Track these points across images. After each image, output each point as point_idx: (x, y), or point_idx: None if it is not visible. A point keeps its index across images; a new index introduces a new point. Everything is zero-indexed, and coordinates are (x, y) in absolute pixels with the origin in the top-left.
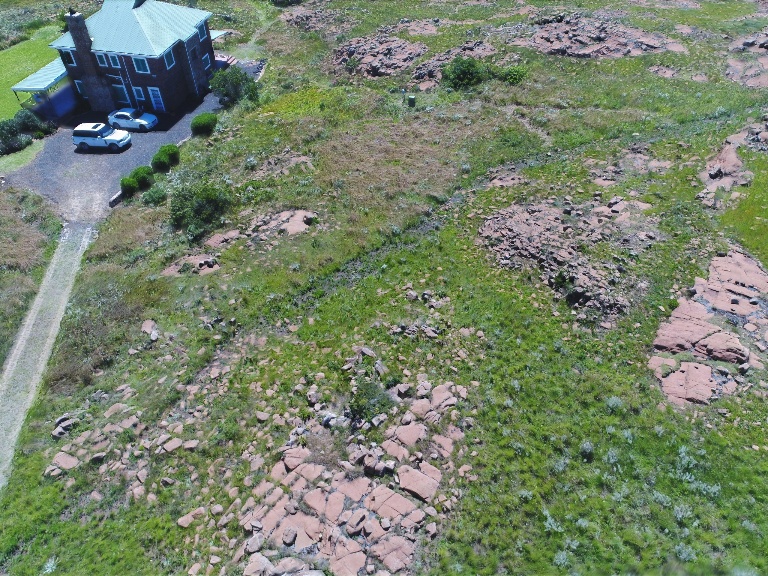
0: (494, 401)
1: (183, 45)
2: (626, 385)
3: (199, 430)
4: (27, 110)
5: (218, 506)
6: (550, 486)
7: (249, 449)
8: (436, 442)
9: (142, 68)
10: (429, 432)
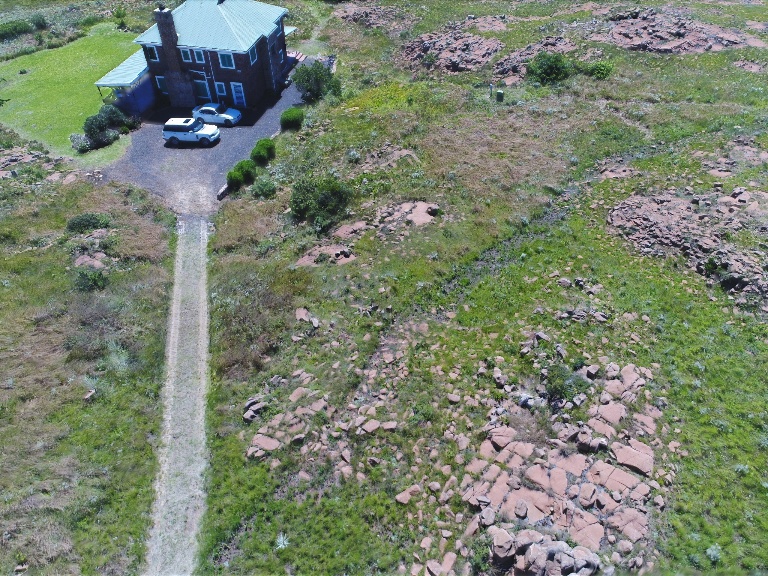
0: (682, 381)
1: (265, 41)
2: None
3: (391, 412)
4: (111, 105)
5: (435, 483)
6: (763, 460)
7: (451, 429)
8: (638, 420)
9: (227, 63)
10: (628, 411)
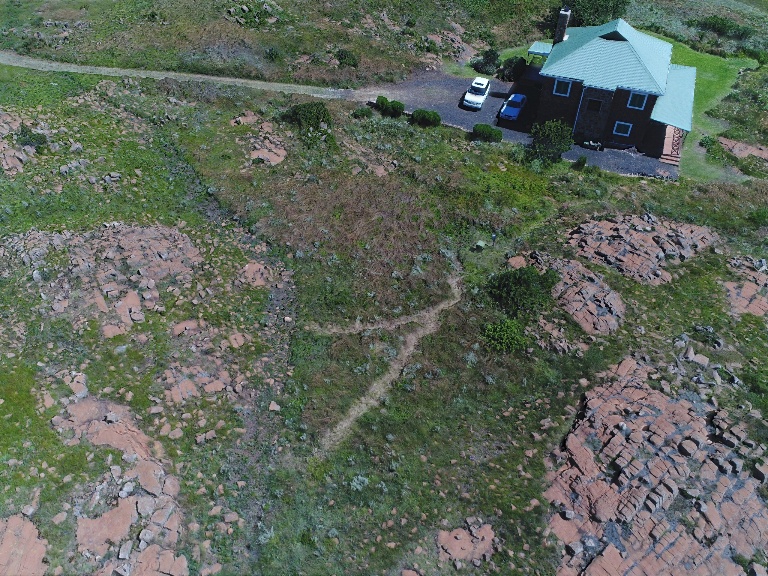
0: None
1: (583, 88)
2: None
3: None
4: (519, 59)
5: (33, 110)
6: None
7: None
8: None
9: None
10: None
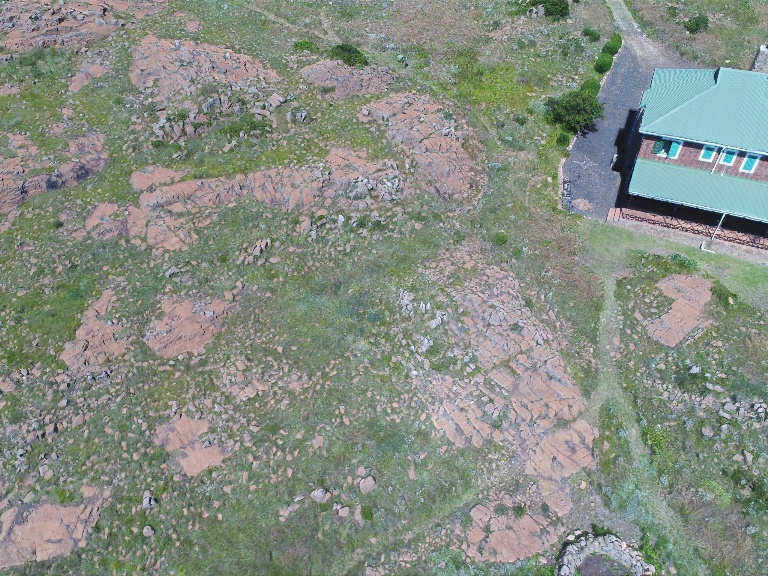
0: None
1: None
2: None
3: None
4: None
5: None
6: None
7: None
8: None
9: None
10: None
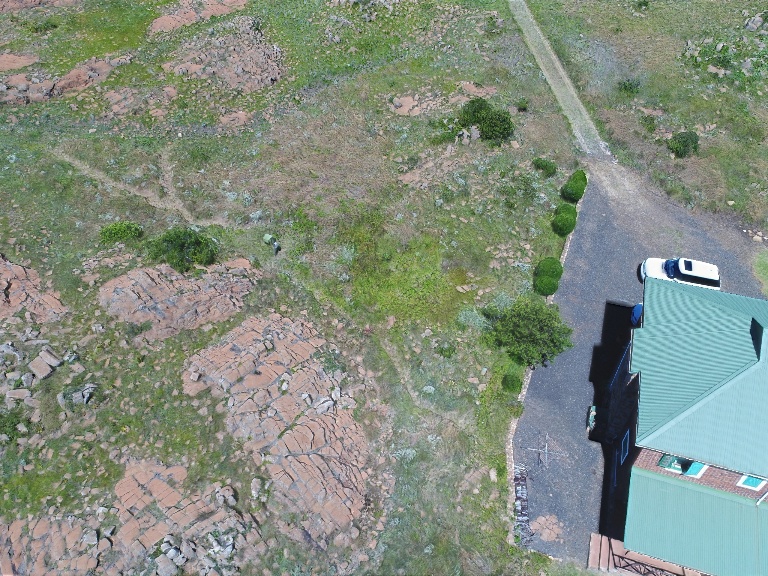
0: None
1: None
2: (260, 2)
3: None
4: None
5: None
6: None
7: None
8: None
9: None
10: None
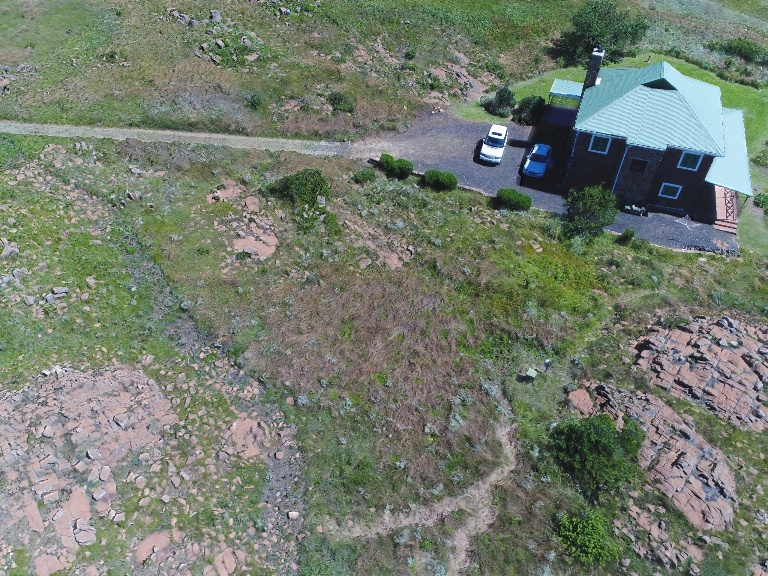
0: None
1: (626, 146)
2: None
3: None
4: (538, 99)
5: None
6: None
7: None
8: None
9: None
10: None
